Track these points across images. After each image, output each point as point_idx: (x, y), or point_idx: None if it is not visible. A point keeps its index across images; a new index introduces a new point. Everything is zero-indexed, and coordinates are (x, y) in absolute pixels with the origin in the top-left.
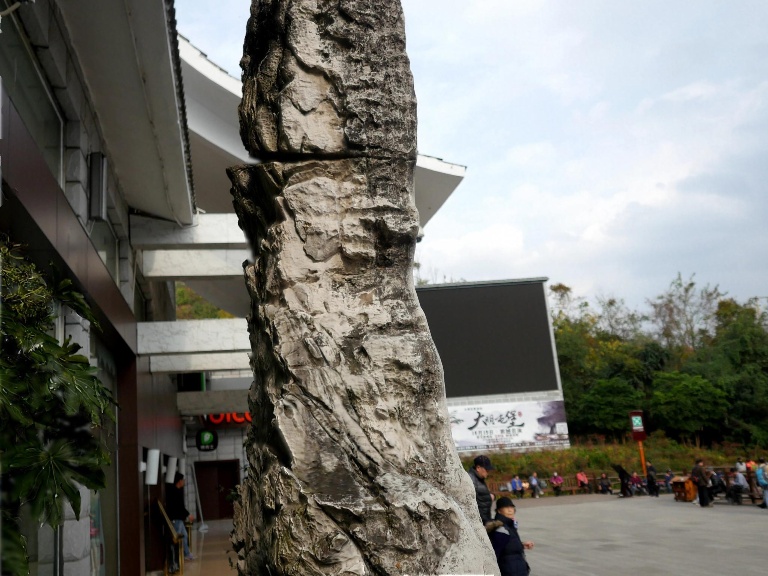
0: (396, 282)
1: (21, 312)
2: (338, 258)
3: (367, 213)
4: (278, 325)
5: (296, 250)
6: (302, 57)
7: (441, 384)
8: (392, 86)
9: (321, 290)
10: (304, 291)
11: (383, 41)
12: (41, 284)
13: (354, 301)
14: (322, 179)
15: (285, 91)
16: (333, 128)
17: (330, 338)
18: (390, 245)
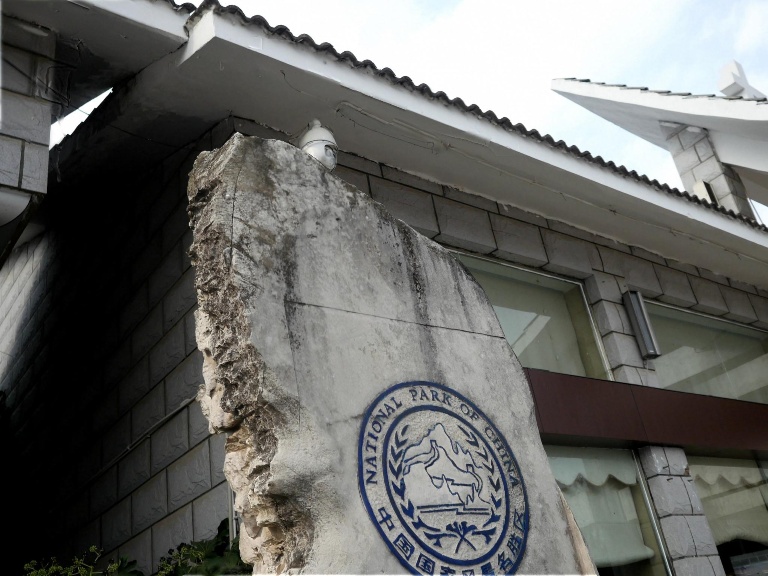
0: (304, 542)
1: None
2: (266, 529)
3: None
4: None
5: None
6: None
7: None
8: (237, 337)
9: (263, 568)
10: None
11: (227, 295)
12: None
13: None
14: (228, 456)
15: None
16: None
17: None
18: None
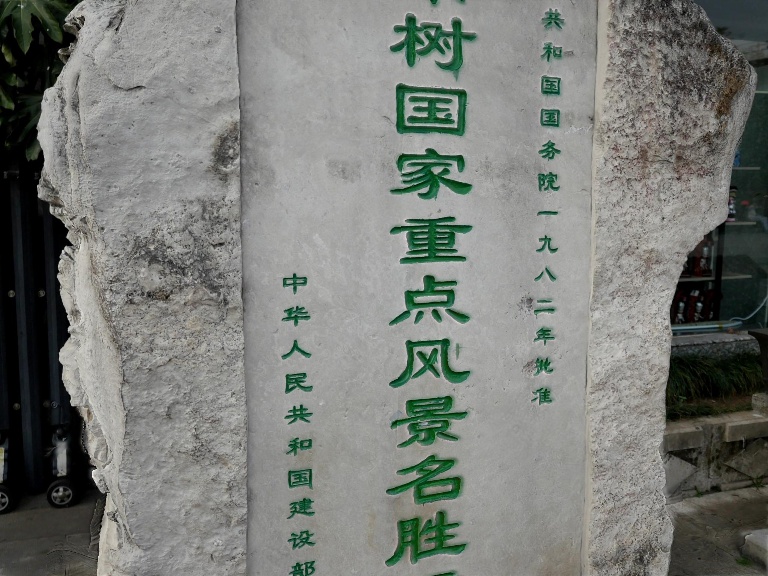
0: None
1: None
2: None
3: None
4: None
5: None
6: None
7: None
8: None
9: None
10: None
11: None
12: None
13: None
14: None
15: None
16: None
17: None
18: None
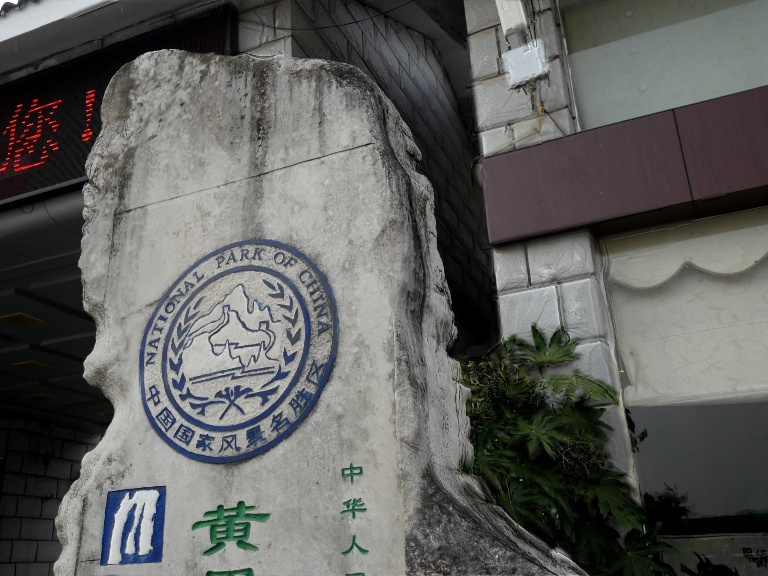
0: None
1: None
2: None
3: None
4: None
5: None
6: None
7: (70, 531)
8: None
9: None
10: None
11: None
12: None
13: None
14: None
15: None
16: None
17: None
18: None
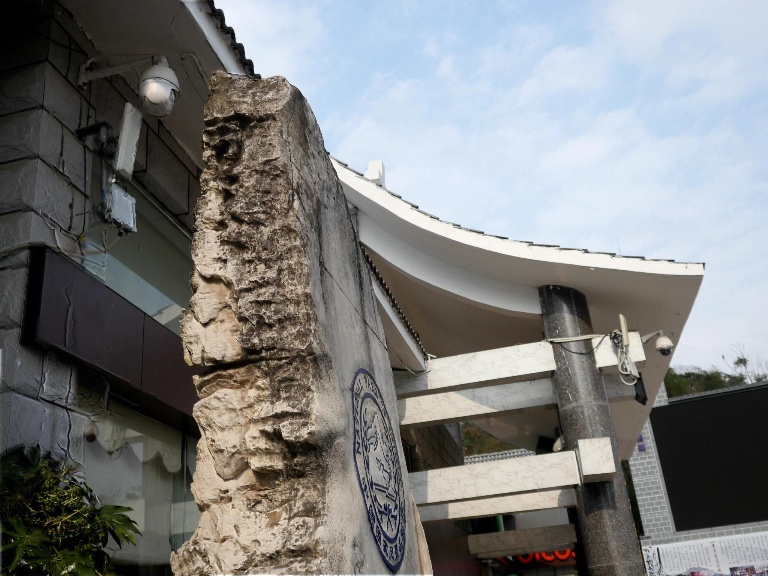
0: (312, 494)
1: (57, 535)
2: (250, 473)
3: (267, 422)
4: (171, 560)
5: (209, 469)
6: (199, 269)
7: None
8: (285, 280)
9: (233, 511)
10: (215, 514)
11: (276, 235)
12: (84, 503)
13: (265, 521)
14: (222, 392)
15: (190, 305)
16: (233, 335)
17: (220, 572)
18: (296, 454)
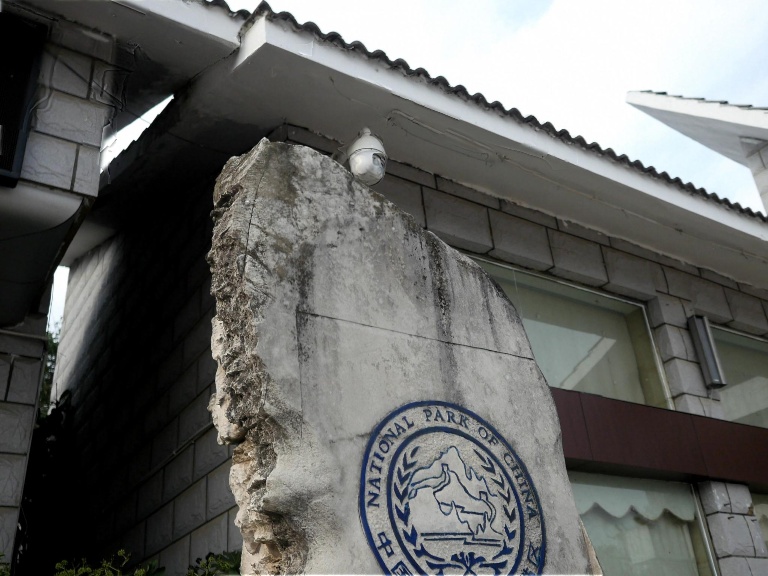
0: (297, 563)
1: None
2: (264, 545)
3: None
4: None
5: None
6: None
7: None
8: None
9: None
10: None
11: None
12: None
13: None
14: None
15: None
16: None
17: None
18: None
